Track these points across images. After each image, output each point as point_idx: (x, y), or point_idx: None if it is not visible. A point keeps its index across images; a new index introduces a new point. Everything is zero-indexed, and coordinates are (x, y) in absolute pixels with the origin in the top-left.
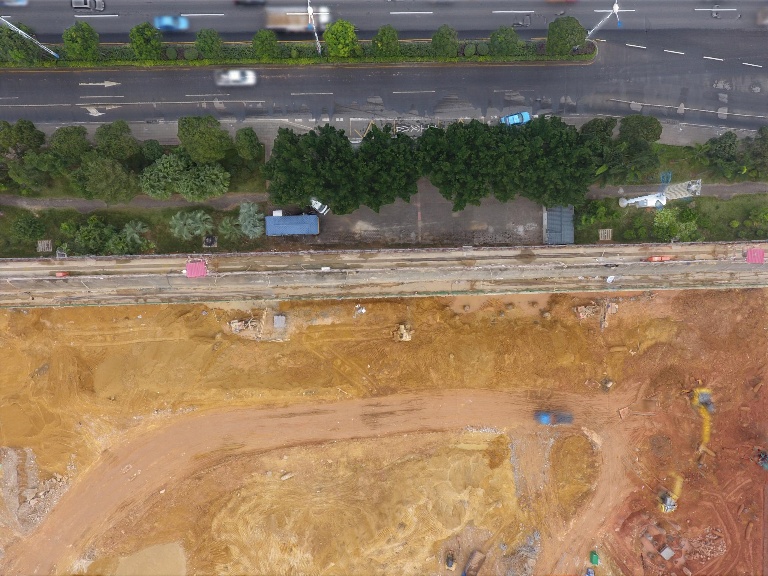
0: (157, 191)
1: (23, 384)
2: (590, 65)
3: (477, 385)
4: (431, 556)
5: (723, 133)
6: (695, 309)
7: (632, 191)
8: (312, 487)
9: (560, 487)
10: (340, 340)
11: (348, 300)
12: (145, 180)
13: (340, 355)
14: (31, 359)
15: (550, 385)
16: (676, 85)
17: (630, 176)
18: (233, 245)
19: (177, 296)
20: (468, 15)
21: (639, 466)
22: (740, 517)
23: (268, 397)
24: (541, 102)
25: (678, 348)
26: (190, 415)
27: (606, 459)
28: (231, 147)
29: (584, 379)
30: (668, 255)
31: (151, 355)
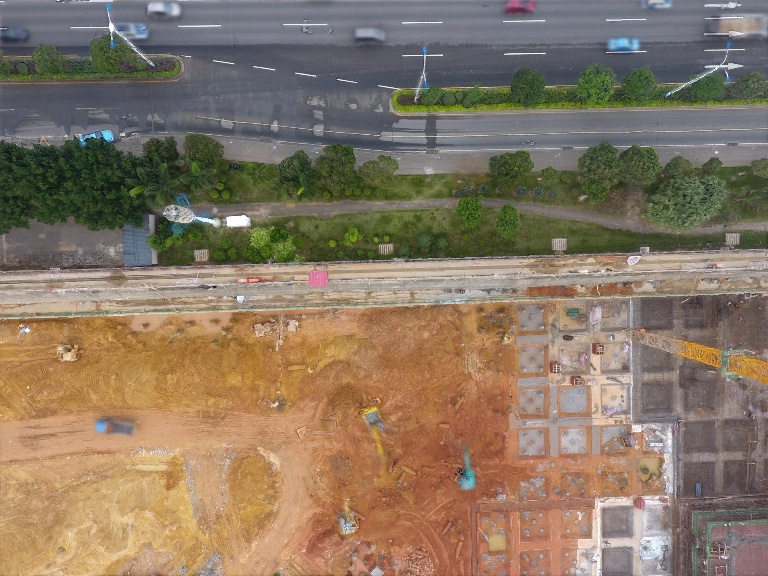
0: None
1: None
2: (177, 82)
3: (142, 406)
4: None
5: (319, 151)
6: (379, 326)
7: (227, 211)
8: None
9: (241, 508)
10: (4, 360)
11: (13, 319)
12: None
13: (3, 376)
14: None
15: (223, 405)
16: (268, 102)
17: (158, 199)
18: None
19: None
20: (45, 31)
21: (321, 486)
22: (445, 536)
23: None
24: (127, 120)
25: (354, 366)
26: None
27: (286, 479)
28: None
29: (257, 398)
30: (266, 276)
31: None
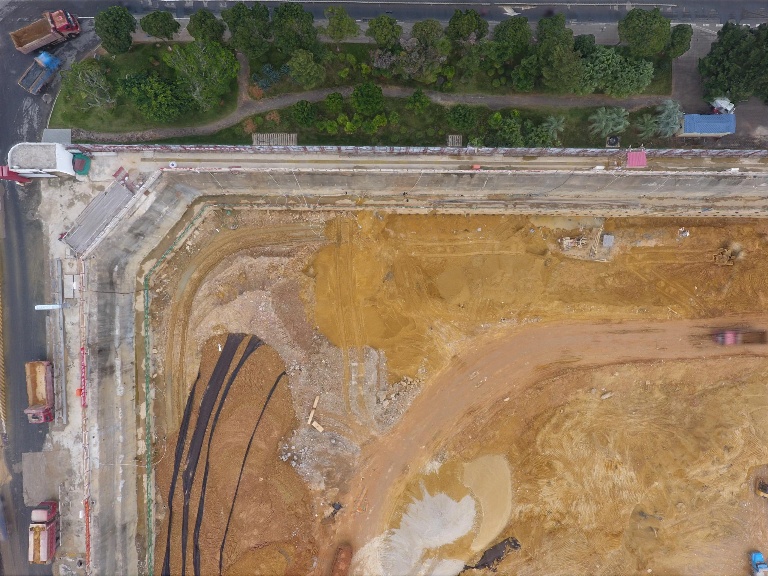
0: (595, 83)
1: (377, 288)
2: None
3: None
4: (745, 483)
5: None
6: None
7: None
8: (628, 408)
9: None
10: (663, 262)
11: (670, 223)
12: (588, 71)
13: (663, 277)
14: (383, 265)
15: None
16: None
17: None
18: (636, 146)
19: (546, 203)
20: None
21: None
22: None
23: (605, 312)
24: None
25: None
26: (534, 325)
27: None
28: (666, 43)
29: None
30: None
31: (496, 266)
